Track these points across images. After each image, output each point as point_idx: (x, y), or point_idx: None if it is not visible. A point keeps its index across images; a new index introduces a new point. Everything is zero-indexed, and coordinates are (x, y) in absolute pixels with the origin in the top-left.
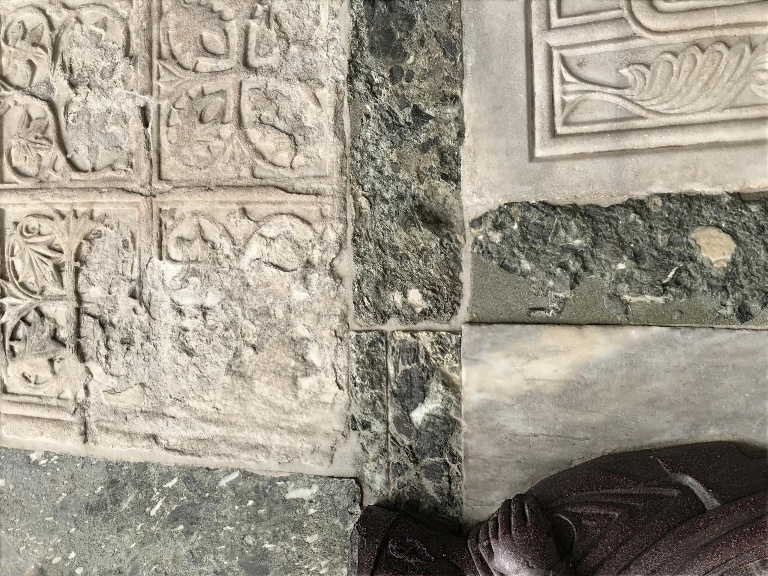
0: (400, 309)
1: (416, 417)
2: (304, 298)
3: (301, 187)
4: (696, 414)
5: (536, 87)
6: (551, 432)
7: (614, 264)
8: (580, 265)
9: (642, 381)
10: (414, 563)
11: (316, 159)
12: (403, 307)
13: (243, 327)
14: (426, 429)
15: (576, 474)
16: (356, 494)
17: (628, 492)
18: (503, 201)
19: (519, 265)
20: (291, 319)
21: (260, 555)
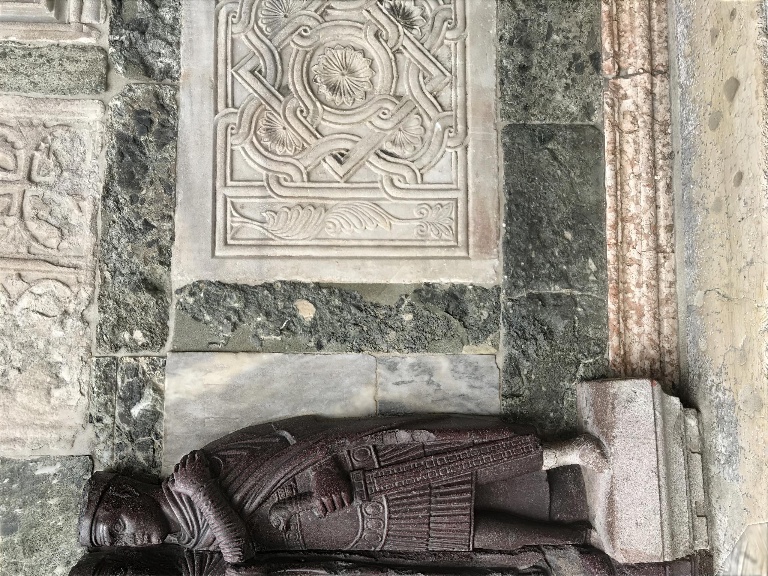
0: (128, 343)
1: (134, 412)
2: (60, 335)
3: (64, 262)
4: (295, 401)
5: (217, 217)
6: (217, 416)
7: (255, 318)
8: (237, 318)
9: (268, 383)
10: (126, 498)
11: (76, 245)
12: (130, 341)
13: (12, 355)
14: (140, 419)
15: (227, 436)
16: (89, 466)
17: (253, 442)
18: (195, 279)
19: (203, 317)
20: (50, 349)
21: (11, 518)
